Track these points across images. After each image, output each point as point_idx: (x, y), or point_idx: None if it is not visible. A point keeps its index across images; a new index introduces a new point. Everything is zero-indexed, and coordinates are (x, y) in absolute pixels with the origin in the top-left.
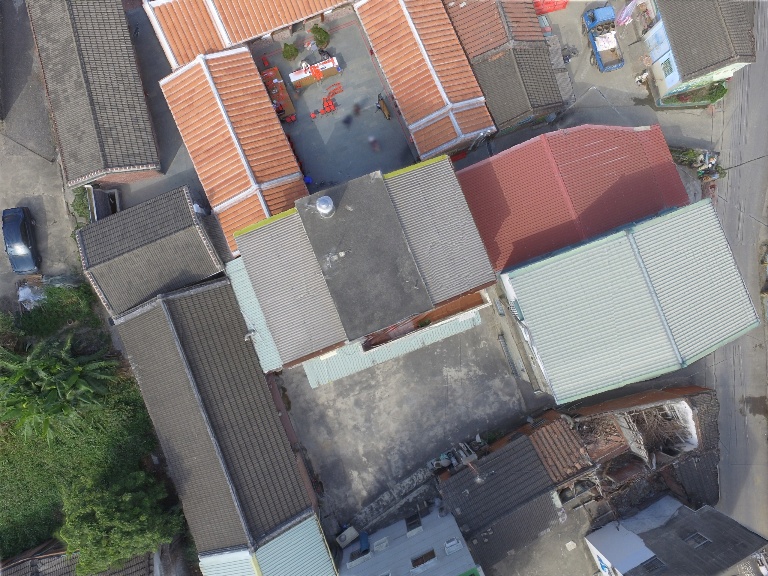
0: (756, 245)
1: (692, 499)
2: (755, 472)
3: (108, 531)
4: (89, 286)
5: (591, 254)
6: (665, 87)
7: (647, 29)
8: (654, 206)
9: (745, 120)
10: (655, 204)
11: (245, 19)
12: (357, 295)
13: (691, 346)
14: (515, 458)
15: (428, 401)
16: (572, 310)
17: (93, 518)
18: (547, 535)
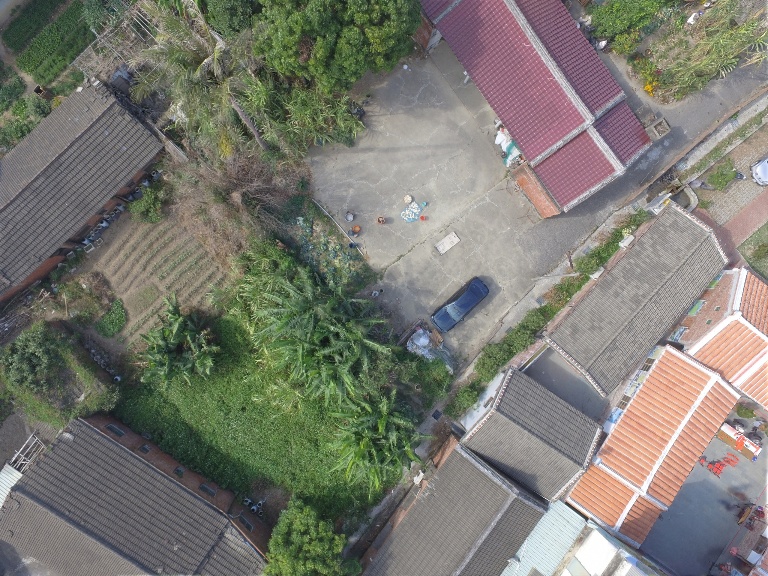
0: None
1: None
2: None
3: None
4: None
5: None
6: None
7: None
8: None
9: None
10: None
11: (766, 386)
12: None
13: None
14: None
15: None
16: None
17: None
18: None
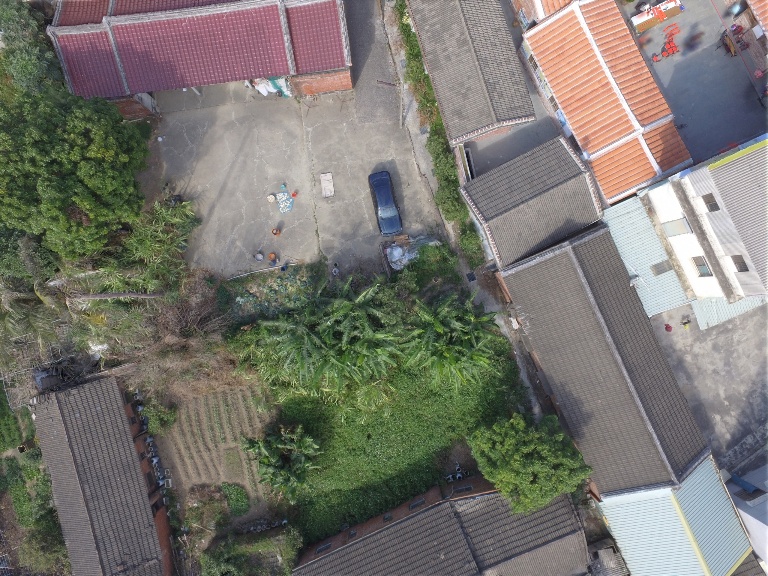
0: None
1: None
2: None
3: (555, 469)
4: (448, 244)
5: None
6: None
7: None
8: None
9: None
10: None
11: None
12: None
13: None
14: None
15: None
16: None
17: (540, 457)
18: None
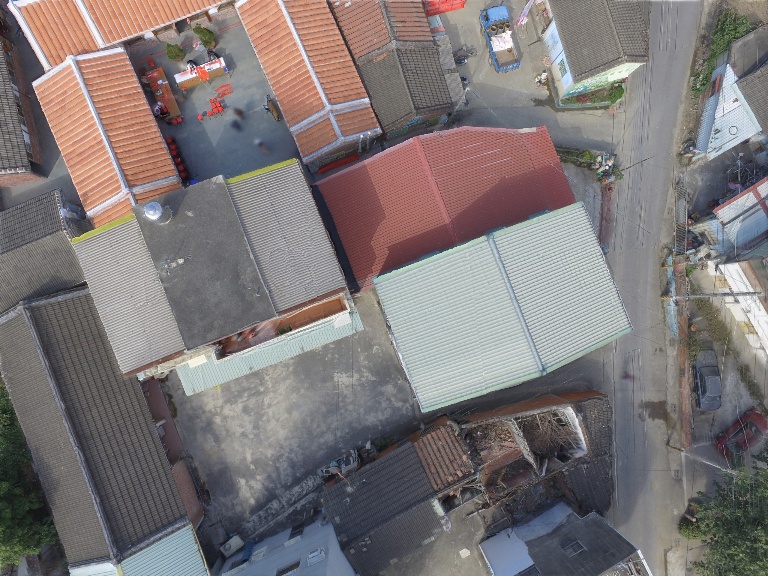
0: (657, 248)
1: (583, 506)
2: (653, 478)
3: None
4: None
5: (453, 259)
6: (562, 88)
7: (546, 29)
8: (537, 209)
9: (647, 121)
10: (538, 207)
11: (118, 19)
12: (196, 303)
13: (554, 353)
14: (398, 465)
15: (318, 407)
16: (436, 316)
17: None
18: (440, 542)
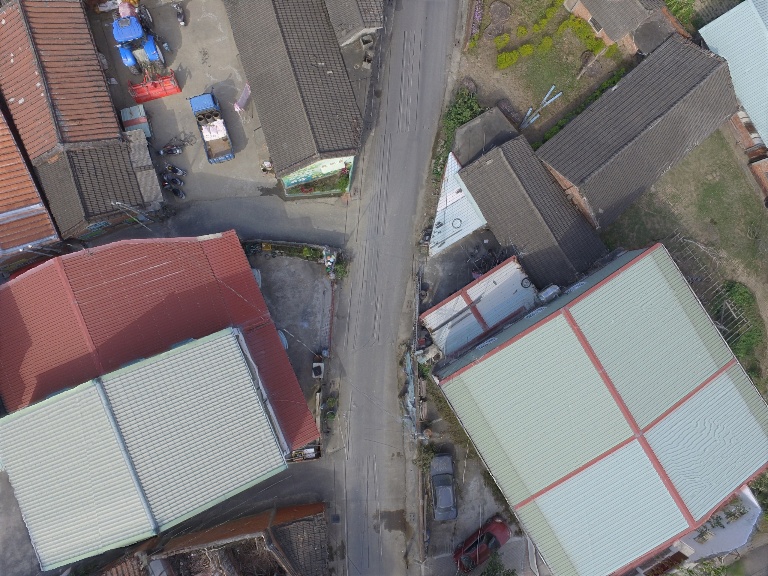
0: (395, 344)
1: None
2: None
3: None
4: None
5: (64, 405)
6: None
7: None
8: (214, 325)
9: (384, 208)
10: (216, 323)
11: None
12: None
13: (174, 507)
14: None
15: (12, 534)
16: (51, 466)
17: None
18: None
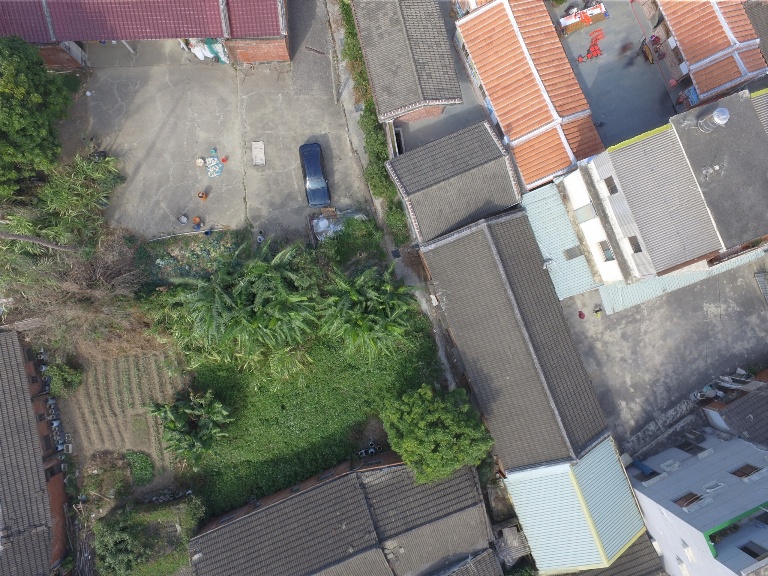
0: None
1: None
2: None
3: (457, 438)
4: (375, 220)
5: None
6: None
7: None
8: None
9: None
10: None
11: None
12: (732, 206)
13: None
14: None
15: (690, 335)
16: None
17: (443, 426)
18: None
